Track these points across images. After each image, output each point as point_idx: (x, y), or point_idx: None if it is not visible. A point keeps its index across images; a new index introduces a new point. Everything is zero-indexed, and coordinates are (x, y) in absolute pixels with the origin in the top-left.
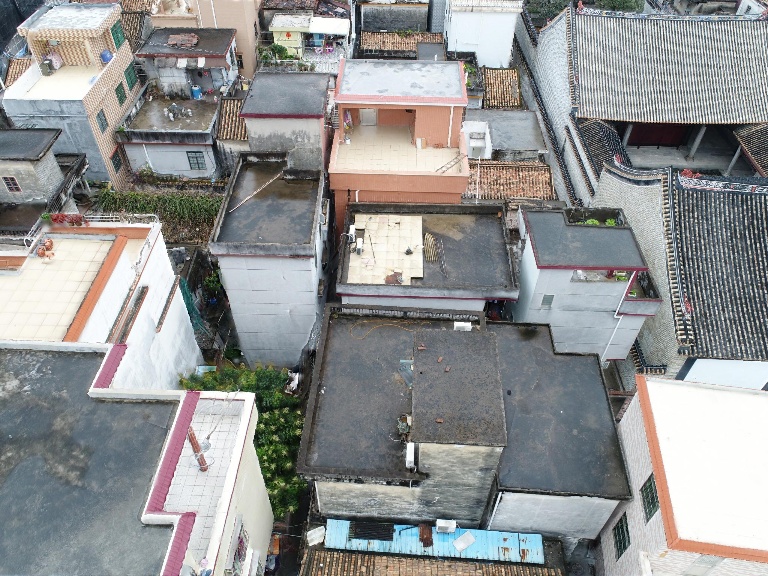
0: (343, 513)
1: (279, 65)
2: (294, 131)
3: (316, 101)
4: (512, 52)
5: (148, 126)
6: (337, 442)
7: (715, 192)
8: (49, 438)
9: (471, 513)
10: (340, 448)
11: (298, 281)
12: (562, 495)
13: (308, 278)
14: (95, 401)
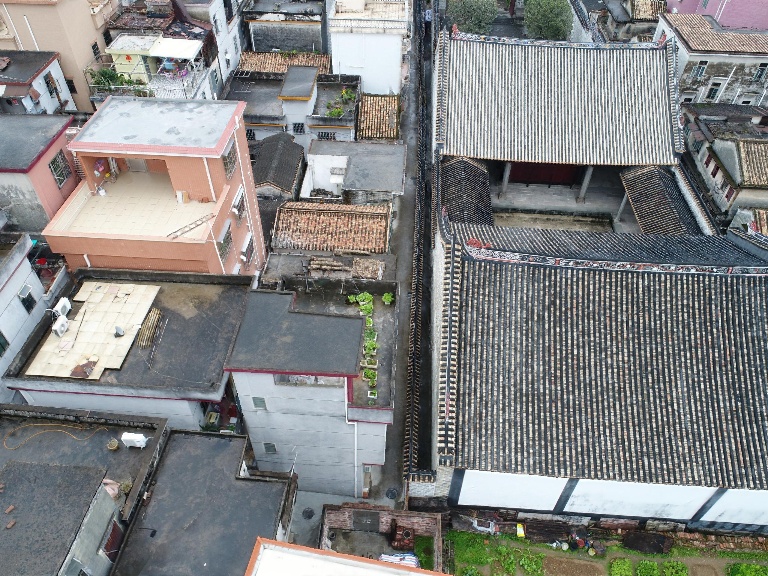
0: None
1: (114, 91)
2: (3, 186)
3: (31, 151)
4: (407, 75)
5: None
6: None
7: (512, 264)
8: None
9: None
10: None
11: None
12: None
13: None
14: None
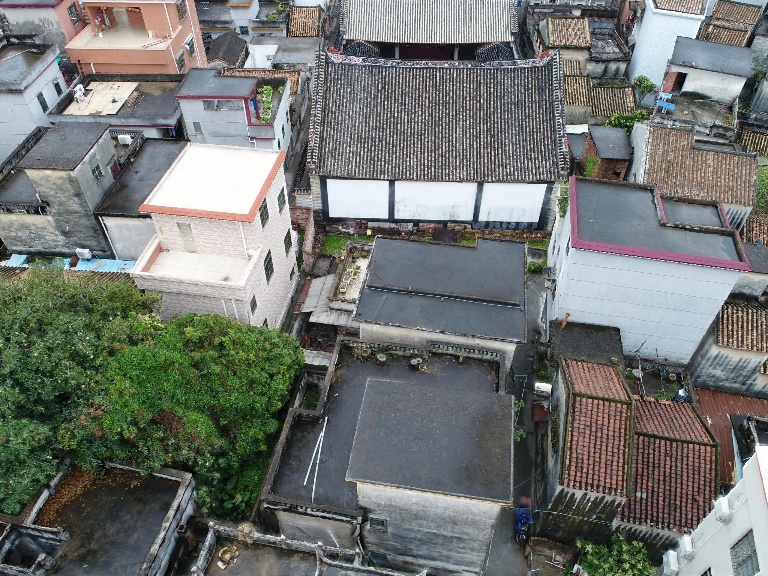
0: (22, 249)
1: None
2: (40, 18)
3: None
4: None
5: None
6: (7, 195)
7: (358, 65)
8: None
9: (98, 243)
10: (8, 197)
11: (22, 114)
12: (134, 217)
13: (28, 111)
14: None
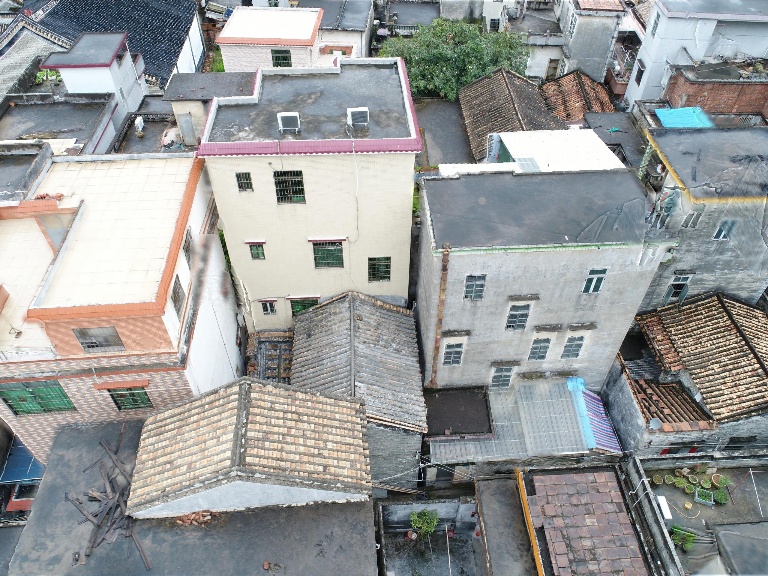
0: None
1: None
2: None
3: None
4: None
5: None
6: None
7: (45, 18)
8: (288, 109)
9: None
10: None
11: None
12: None
13: None
14: (261, 101)
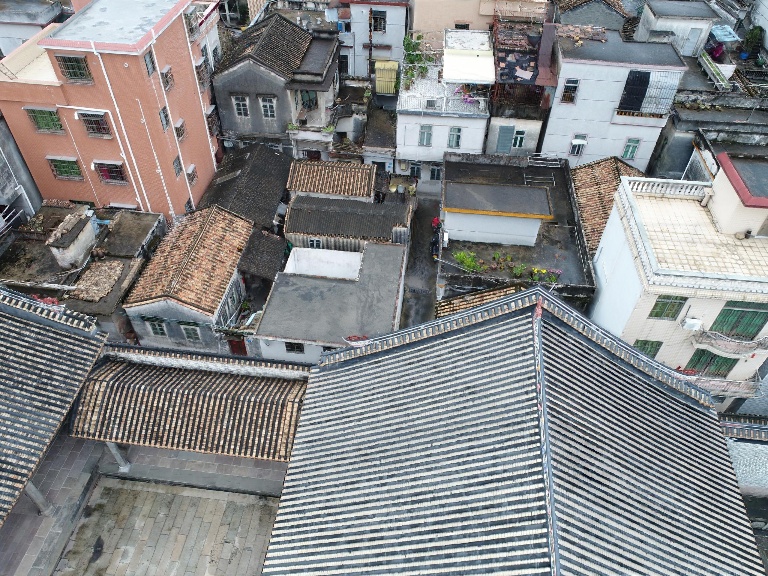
0: None
1: None
2: None
3: None
4: None
5: (292, 16)
6: None
7: None
8: None
9: None
10: None
11: None
12: None
13: None
14: None
